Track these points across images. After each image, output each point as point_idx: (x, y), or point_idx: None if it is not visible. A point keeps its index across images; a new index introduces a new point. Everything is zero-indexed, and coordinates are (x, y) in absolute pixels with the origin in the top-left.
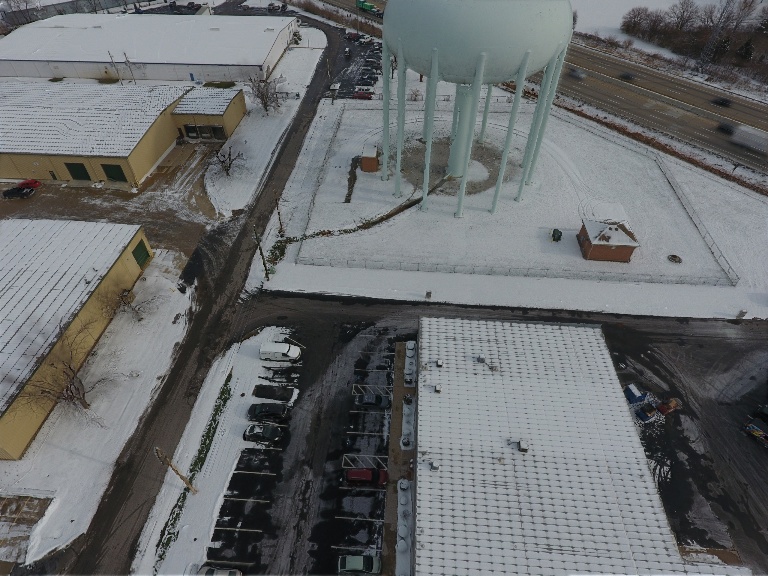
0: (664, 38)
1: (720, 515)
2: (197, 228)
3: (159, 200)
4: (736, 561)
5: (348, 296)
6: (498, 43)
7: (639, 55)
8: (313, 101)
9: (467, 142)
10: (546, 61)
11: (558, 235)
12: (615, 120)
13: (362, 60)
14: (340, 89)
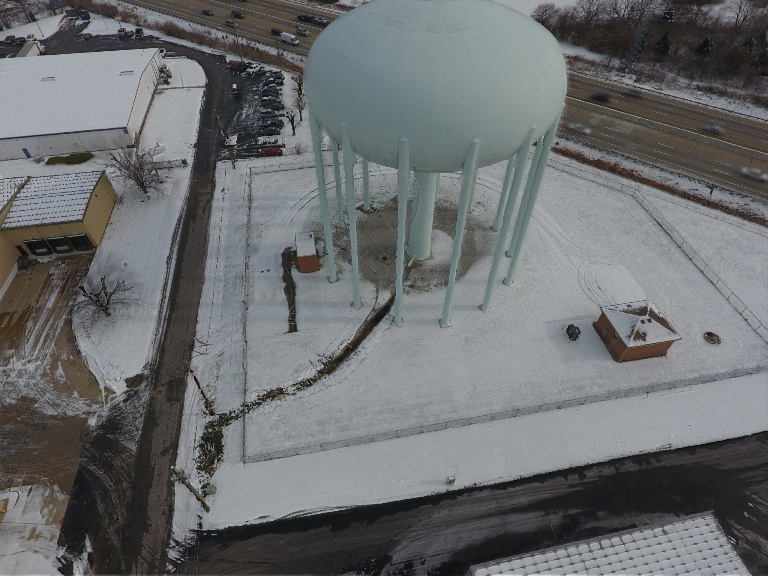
0: (578, 36)
1: None
2: (74, 427)
3: (2, 383)
4: None
5: (337, 511)
6: (495, 124)
7: None
8: (207, 167)
9: (454, 246)
10: (547, 130)
11: (577, 334)
12: (568, 145)
13: (256, 98)
14: (238, 144)
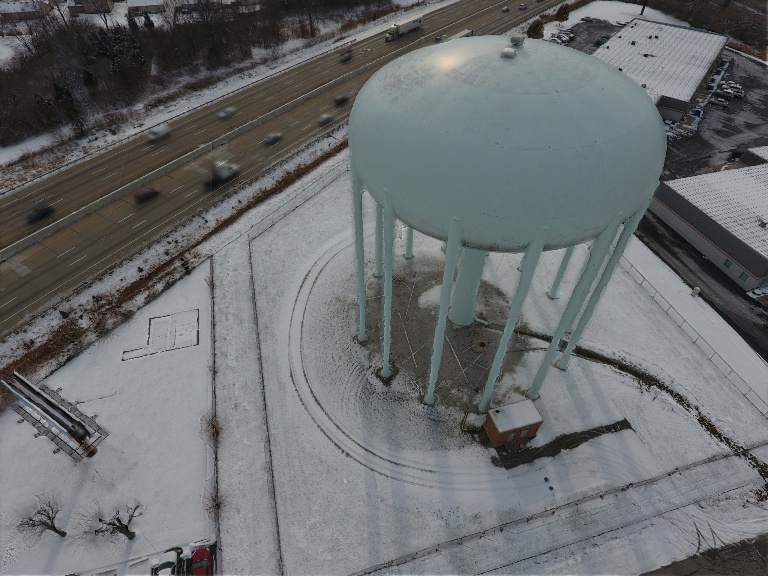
0: None
1: (698, 169)
2: None
3: None
4: (716, 167)
5: (764, 358)
6: None
7: (7, 172)
8: None
9: None
10: None
11: None
12: (246, 195)
13: None
14: None
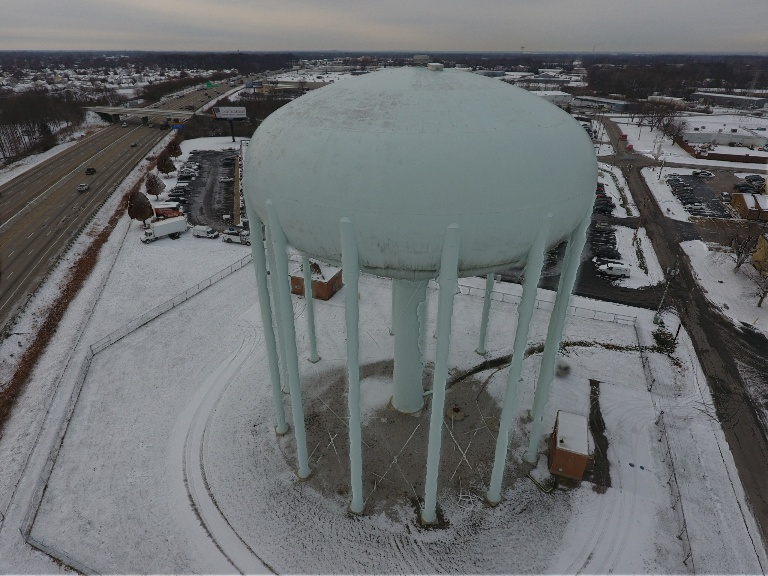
0: None
1: None
2: None
3: None
4: None
5: None
6: None
7: None
8: None
9: None
10: None
11: None
12: None
13: None
14: None
